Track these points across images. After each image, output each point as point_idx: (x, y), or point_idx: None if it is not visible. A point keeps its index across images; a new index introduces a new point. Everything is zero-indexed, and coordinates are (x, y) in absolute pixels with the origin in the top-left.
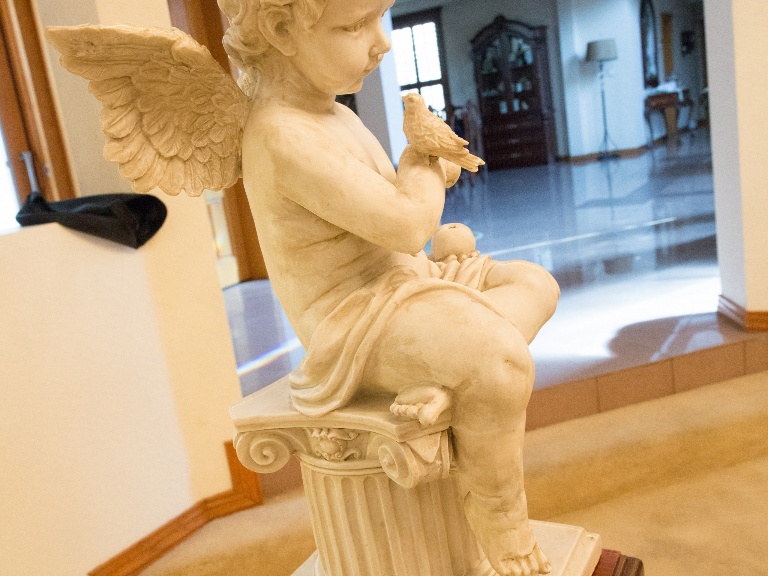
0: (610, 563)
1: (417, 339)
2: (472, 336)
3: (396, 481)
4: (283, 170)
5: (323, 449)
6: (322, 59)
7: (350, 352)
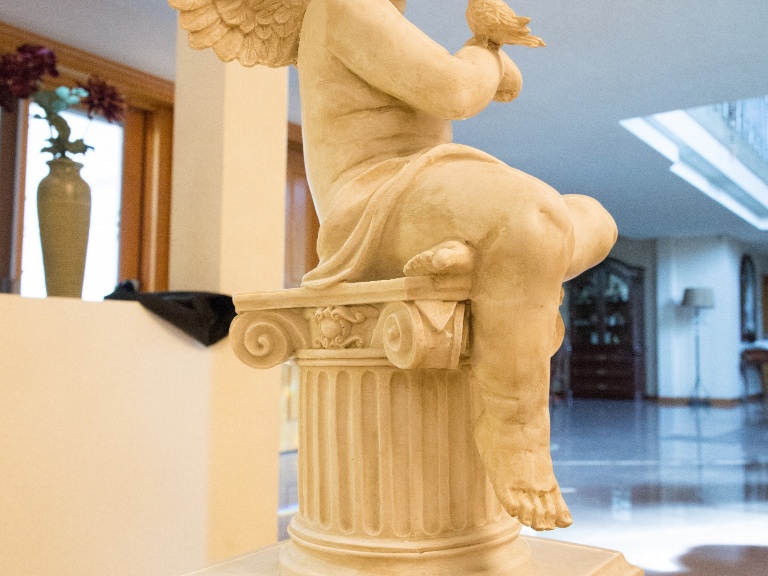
0: None
1: (445, 187)
2: (506, 182)
3: (398, 364)
4: (336, 18)
5: (323, 331)
6: None
7: (371, 212)
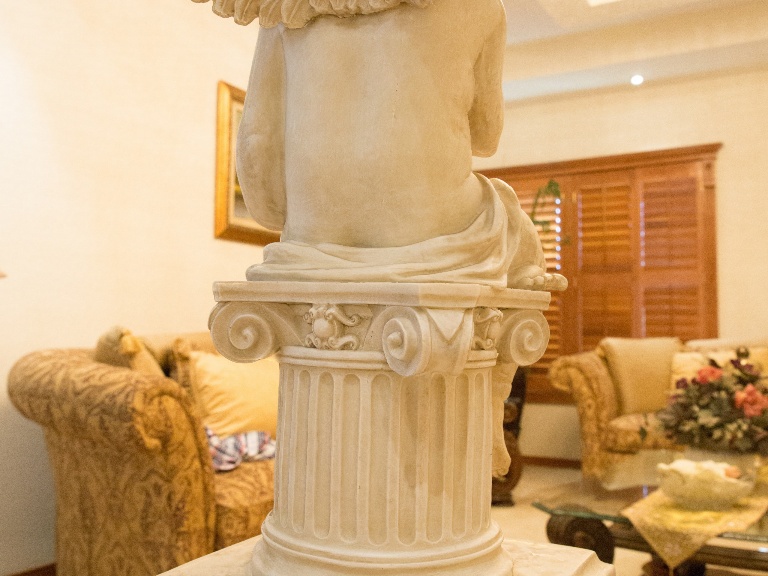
0: None
1: None
2: None
3: (520, 362)
4: (503, 27)
5: (495, 332)
6: None
7: None
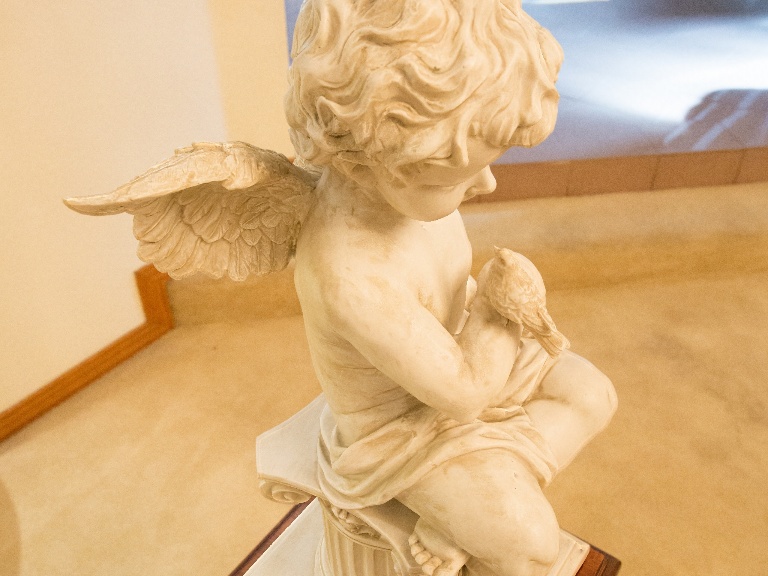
0: (591, 570)
1: (448, 510)
2: (503, 531)
3: None
4: (337, 325)
5: None
6: (405, 205)
7: (380, 480)
